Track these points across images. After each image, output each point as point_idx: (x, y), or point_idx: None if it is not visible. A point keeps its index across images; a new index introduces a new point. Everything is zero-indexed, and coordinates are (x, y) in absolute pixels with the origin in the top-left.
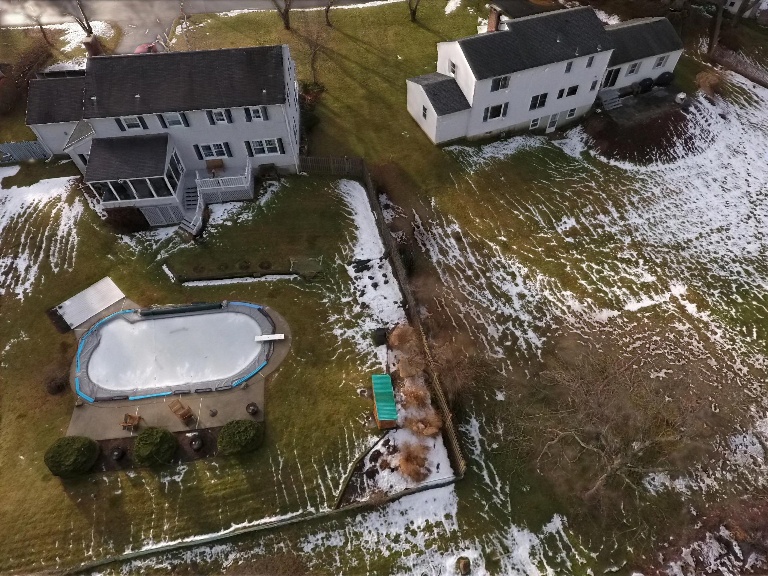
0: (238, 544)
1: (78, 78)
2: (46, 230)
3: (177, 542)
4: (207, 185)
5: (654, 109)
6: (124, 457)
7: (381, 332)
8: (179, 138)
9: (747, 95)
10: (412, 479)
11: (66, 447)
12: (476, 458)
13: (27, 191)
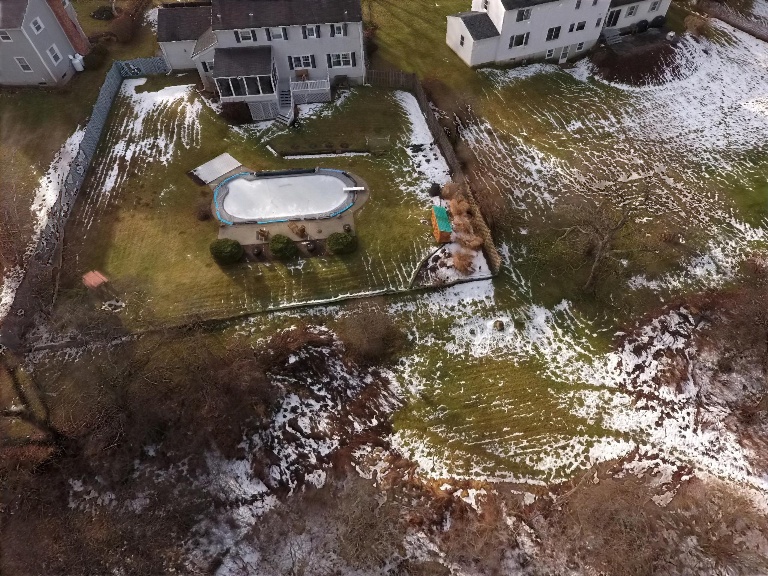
0: (344, 306)
1: (195, 8)
2: (176, 121)
3: (303, 303)
4: (298, 87)
5: (648, 44)
6: (261, 254)
7: (436, 186)
8: (278, 50)
9: (727, 37)
10: (462, 274)
11: (223, 243)
12: (507, 266)
13: (156, 95)
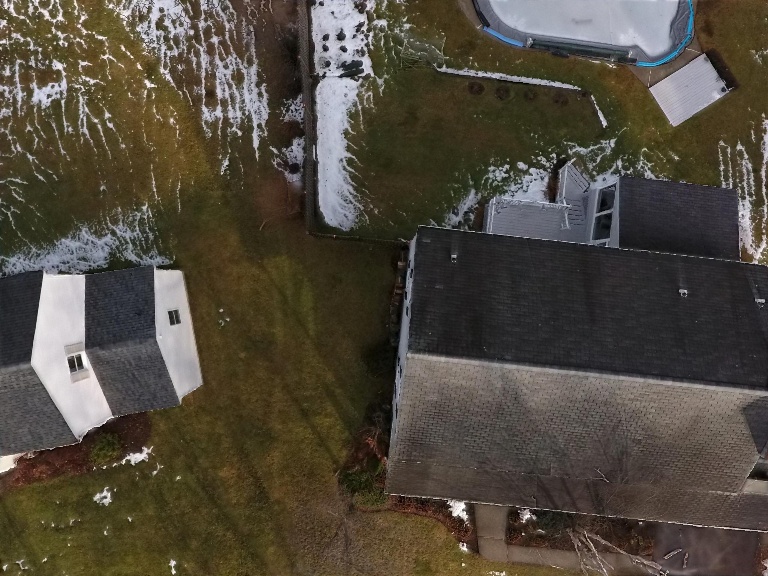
0: None
1: None
2: (767, 214)
3: None
4: None
5: None
6: None
7: None
8: None
9: None
10: None
11: None
12: None
13: None
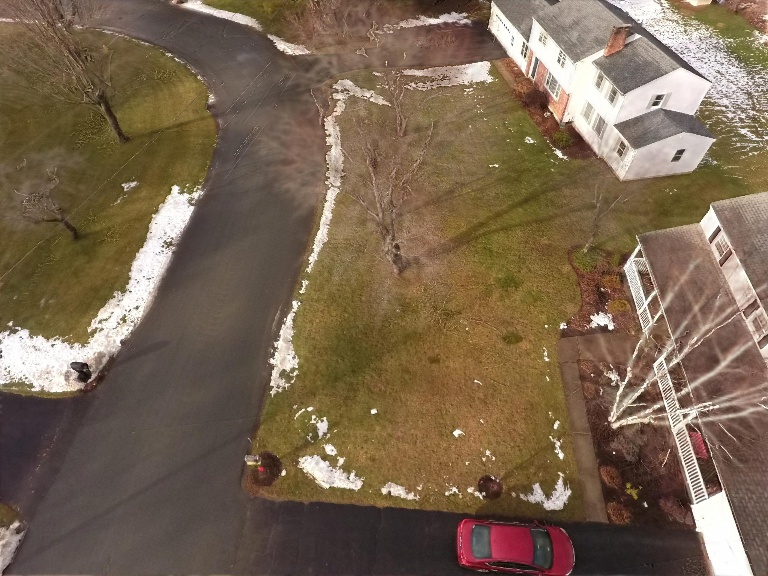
0: None
1: None
2: None
3: None
4: None
5: None
6: None
7: None
8: None
9: None
10: None
11: None
12: None
13: None
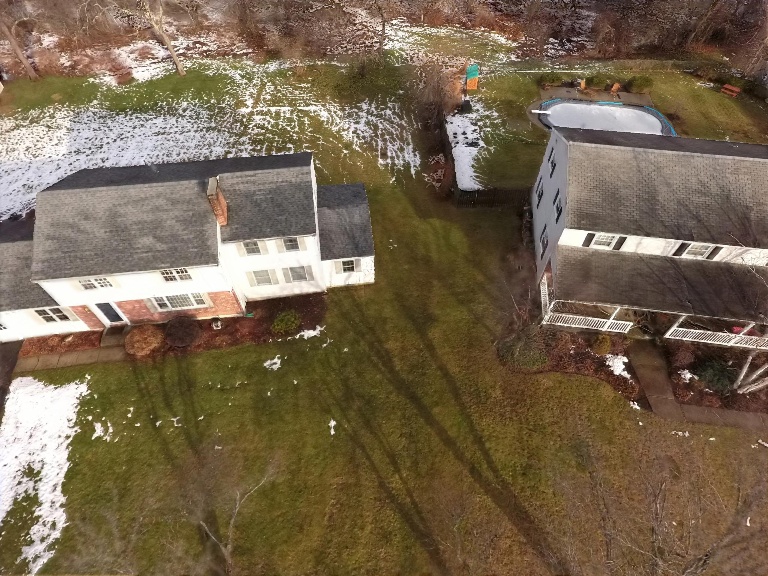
0: None
1: None
2: None
3: (573, 71)
4: None
5: None
6: None
7: (467, 101)
8: None
9: None
10: None
11: (643, 81)
12: None
13: None
